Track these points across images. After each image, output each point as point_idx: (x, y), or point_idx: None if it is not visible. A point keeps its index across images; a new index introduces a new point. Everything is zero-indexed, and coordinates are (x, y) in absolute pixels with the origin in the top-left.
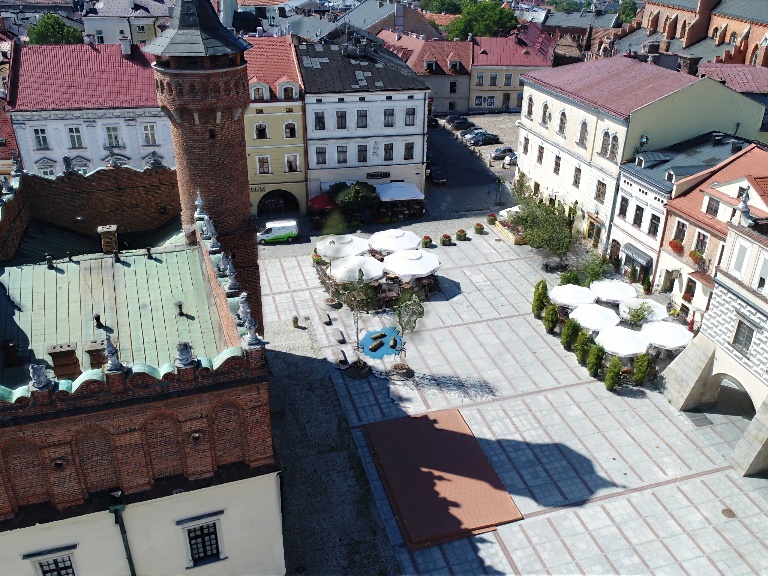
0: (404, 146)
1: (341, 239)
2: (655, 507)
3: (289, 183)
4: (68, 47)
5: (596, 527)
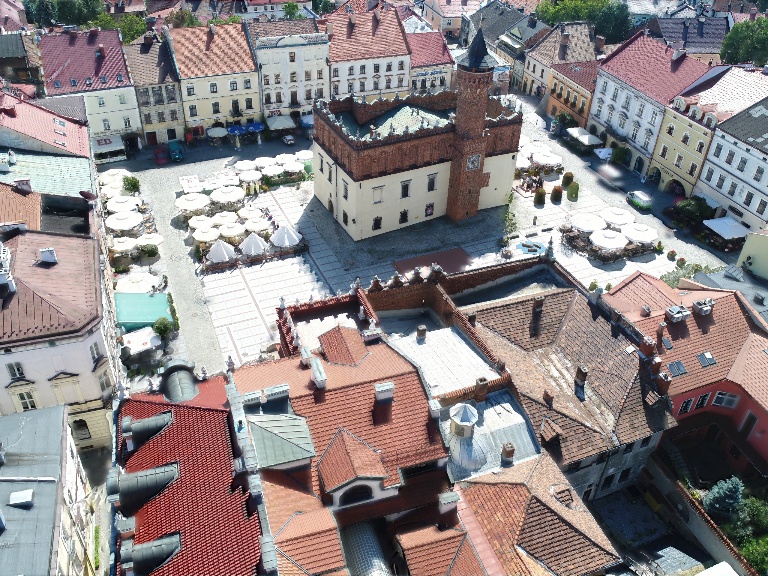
0: (761, 201)
1: (615, 210)
2: None
3: (686, 181)
4: (658, 44)
5: None
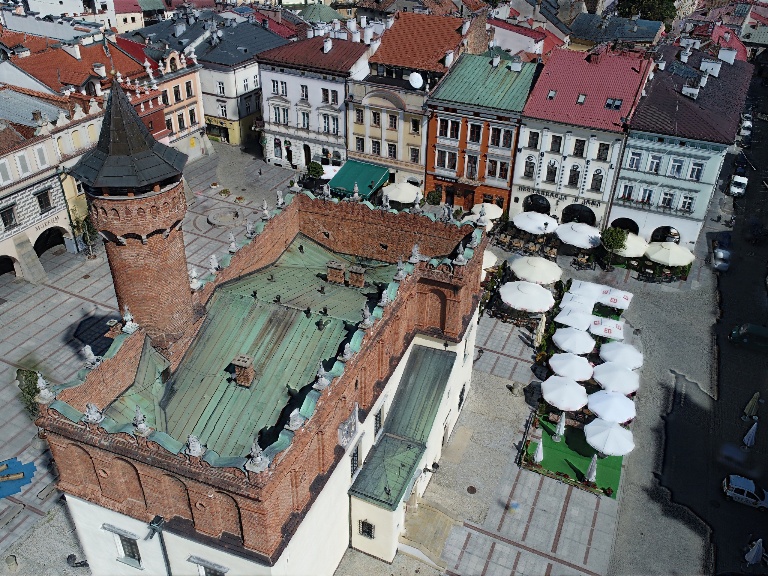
0: None
1: None
2: (104, 294)
3: None
4: None
5: None
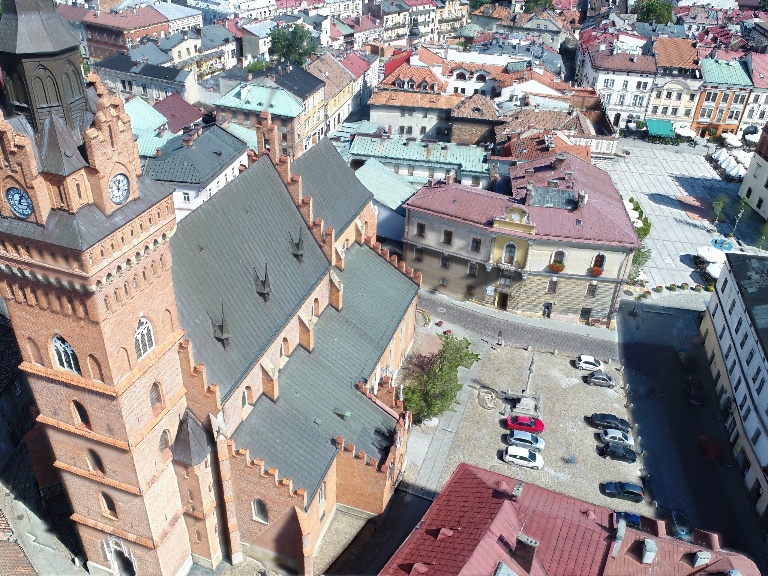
0: None
1: None
2: None
3: None
4: None
5: (655, 190)
